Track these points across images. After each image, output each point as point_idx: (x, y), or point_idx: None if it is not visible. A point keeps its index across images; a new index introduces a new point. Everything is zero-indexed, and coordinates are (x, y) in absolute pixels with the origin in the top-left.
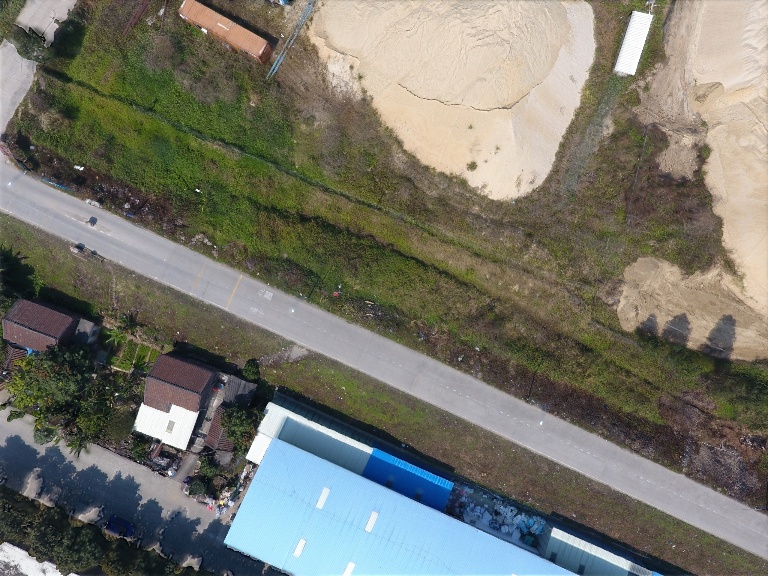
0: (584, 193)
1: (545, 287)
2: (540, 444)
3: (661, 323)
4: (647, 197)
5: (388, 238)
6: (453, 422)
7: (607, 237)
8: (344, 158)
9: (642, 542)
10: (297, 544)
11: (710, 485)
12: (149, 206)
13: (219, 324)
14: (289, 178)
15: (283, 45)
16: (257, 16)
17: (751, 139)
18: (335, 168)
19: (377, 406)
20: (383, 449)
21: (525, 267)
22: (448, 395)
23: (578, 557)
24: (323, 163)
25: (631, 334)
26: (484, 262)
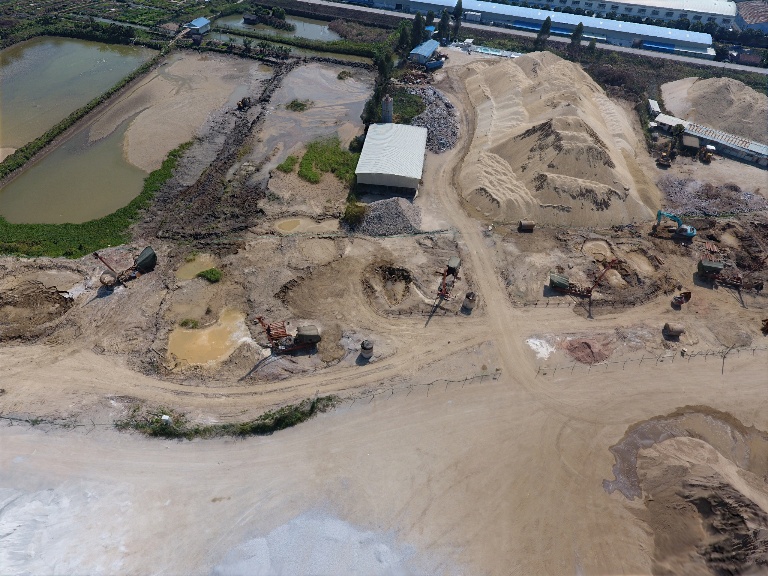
0: None
1: None
2: None
3: None
4: None
5: None
6: None
7: None
8: None
9: None
10: (688, 31)
11: None
12: None
13: None
14: None
15: None
16: None
17: None
18: None
19: None
20: None
21: None
22: None
23: (595, 35)
24: None
25: None
26: None
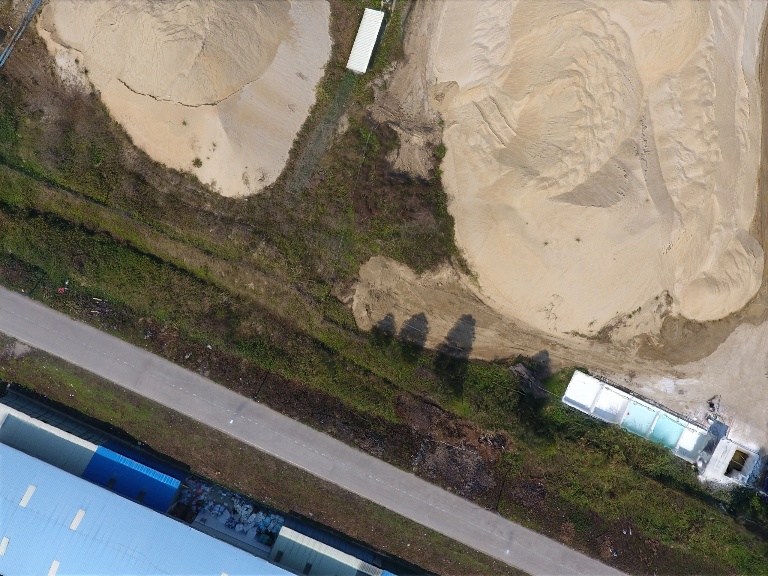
0: (317, 191)
1: (279, 285)
2: (268, 443)
3: (399, 322)
4: (370, 196)
5: (123, 234)
6: (178, 420)
7: (341, 235)
8: (71, 153)
9: (379, 541)
10: (0, 542)
11: (440, 484)
12: None
13: None
14: (14, 173)
15: (10, 38)
16: None
17: (477, 138)
18: (58, 163)
19: (106, 404)
20: (116, 447)
21: (257, 265)
22: (174, 393)
23: (306, 556)
24: None
25: (367, 333)
26: (215, 259)
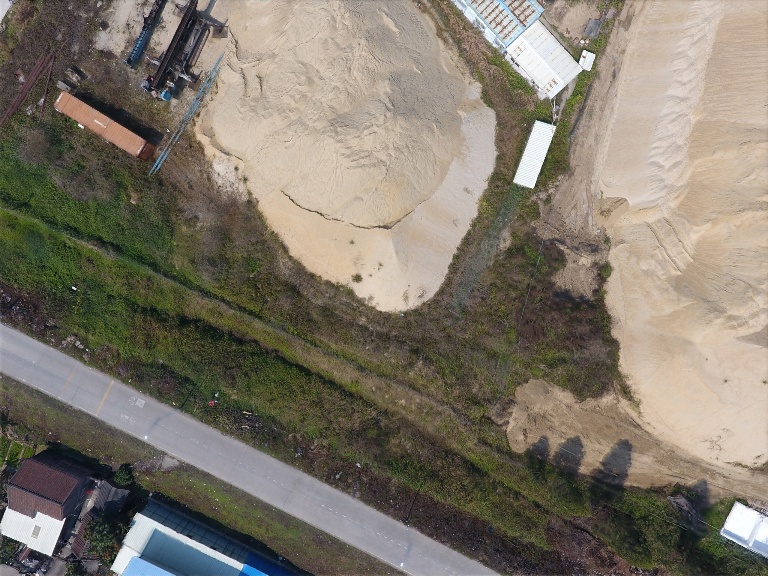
0: (476, 309)
1: (432, 403)
2: (417, 568)
3: (553, 445)
4: (538, 320)
5: (272, 344)
6: (327, 542)
7: (499, 355)
8: (226, 262)
9: None
10: None
11: None
12: (21, 304)
13: (89, 429)
14: (168, 281)
15: (168, 141)
16: (142, 109)
17: (651, 263)
18: (214, 274)
19: (251, 519)
20: (258, 562)
21: (411, 383)
22: (323, 514)
23: None
24: (202, 268)
25: (520, 456)
26: (369, 376)
